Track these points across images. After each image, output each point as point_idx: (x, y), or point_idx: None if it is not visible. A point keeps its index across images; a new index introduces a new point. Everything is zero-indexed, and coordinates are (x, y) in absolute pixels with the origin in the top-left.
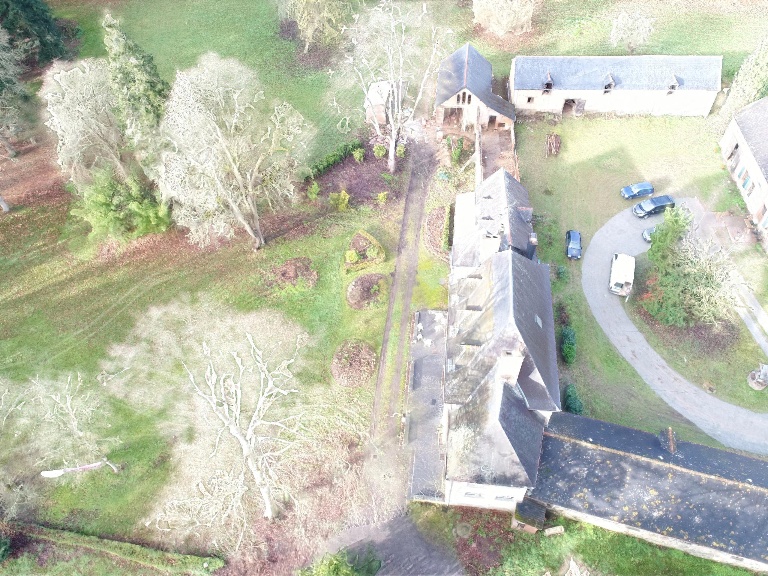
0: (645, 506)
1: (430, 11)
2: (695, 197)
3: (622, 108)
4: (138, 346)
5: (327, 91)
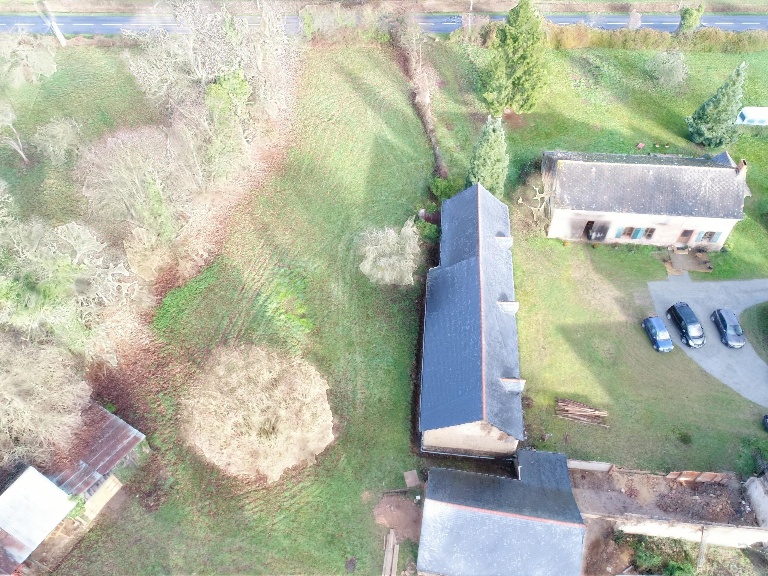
0: None
1: (157, 575)
2: None
3: None
4: None
5: None
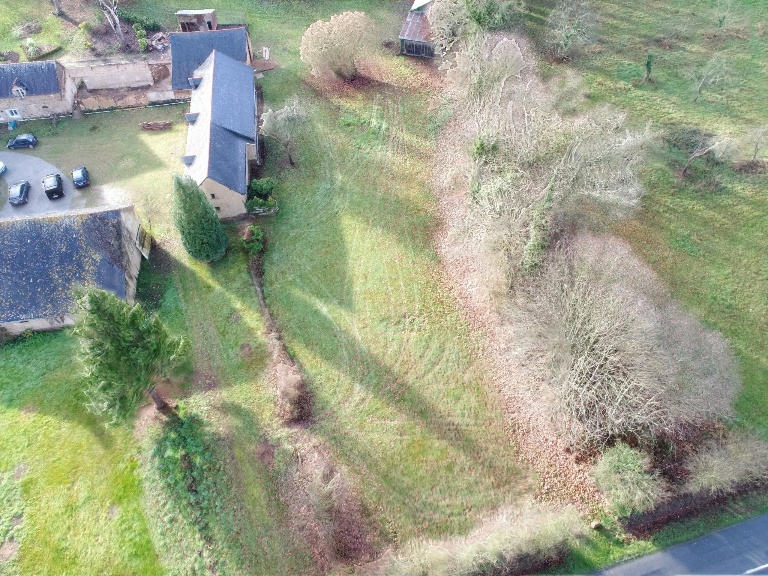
0: None
1: (369, 29)
2: None
3: None
4: None
5: (230, 5)
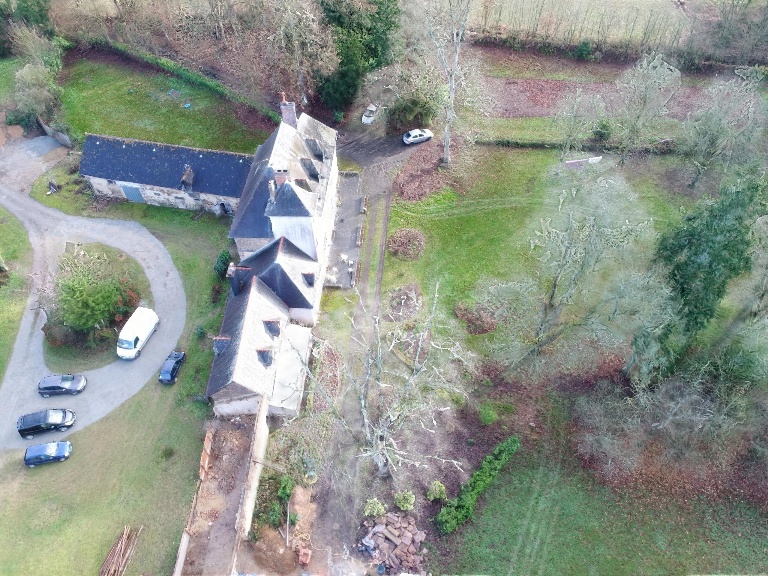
0: None
1: None
2: None
3: None
4: None
5: None
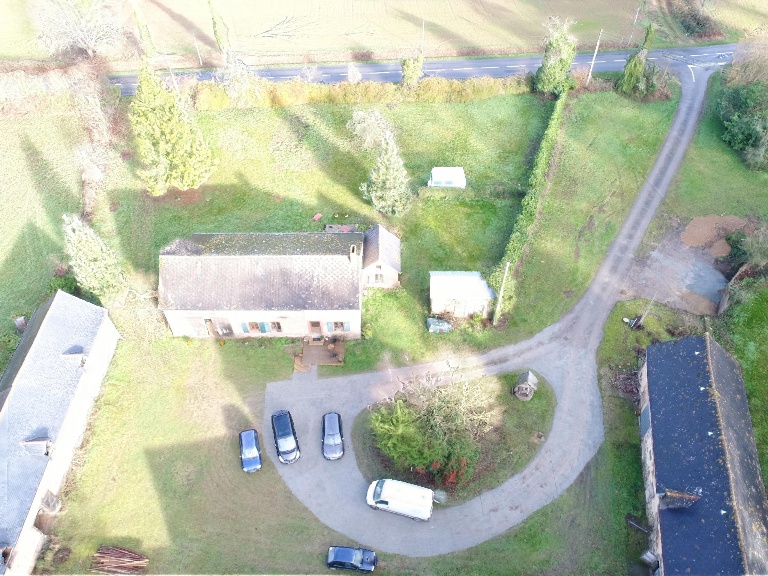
0: (764, 539)
1: None
2: None
3: (75, 437)
4: None
5: None
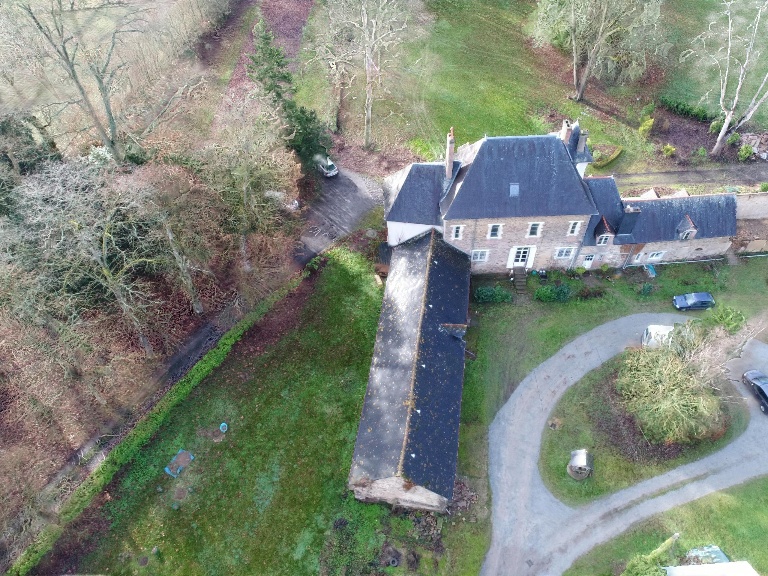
0: (395, 308)
1: None
2: (761, 320)
3: None
4: (463, 70)
5: None
